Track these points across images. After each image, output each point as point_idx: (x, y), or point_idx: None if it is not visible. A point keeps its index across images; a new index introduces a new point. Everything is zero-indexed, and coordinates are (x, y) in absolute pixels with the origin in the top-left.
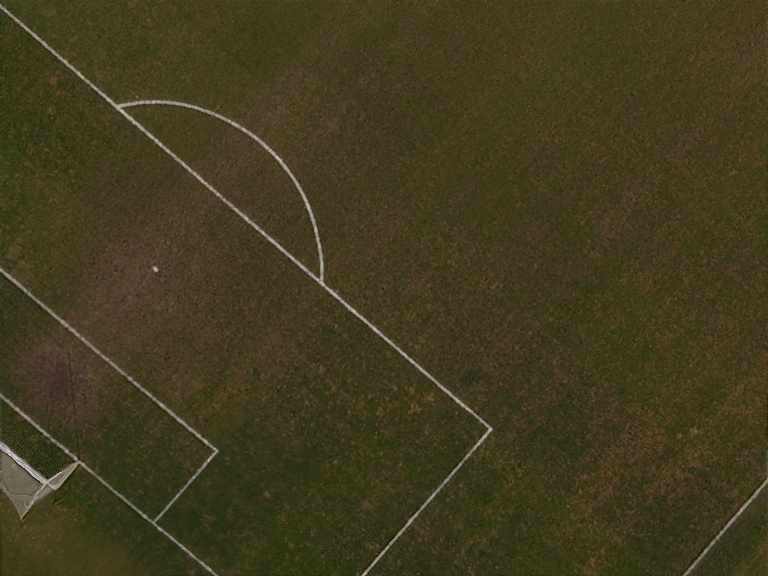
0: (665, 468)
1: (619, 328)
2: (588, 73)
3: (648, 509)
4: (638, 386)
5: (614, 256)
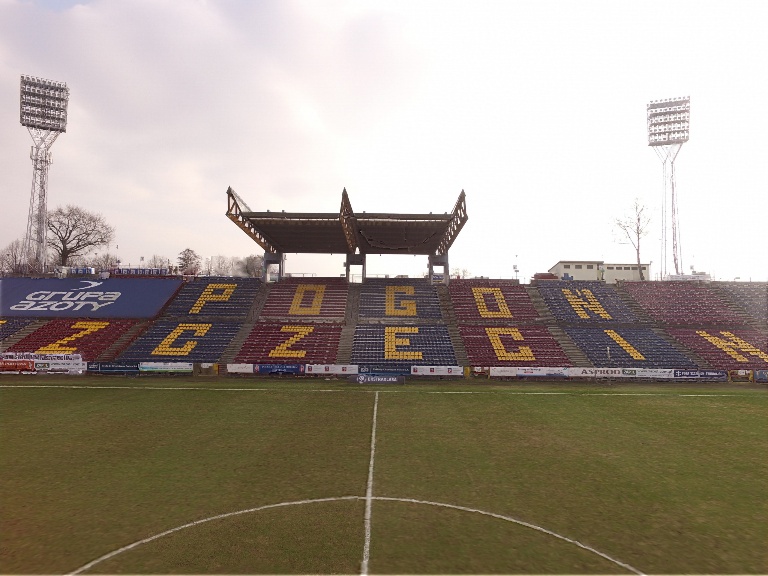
0: (743, 406)
1: (766, 427)
2: (759, 485)
3: (763, 404)
4: (756, 417)
5: (761, 438)
